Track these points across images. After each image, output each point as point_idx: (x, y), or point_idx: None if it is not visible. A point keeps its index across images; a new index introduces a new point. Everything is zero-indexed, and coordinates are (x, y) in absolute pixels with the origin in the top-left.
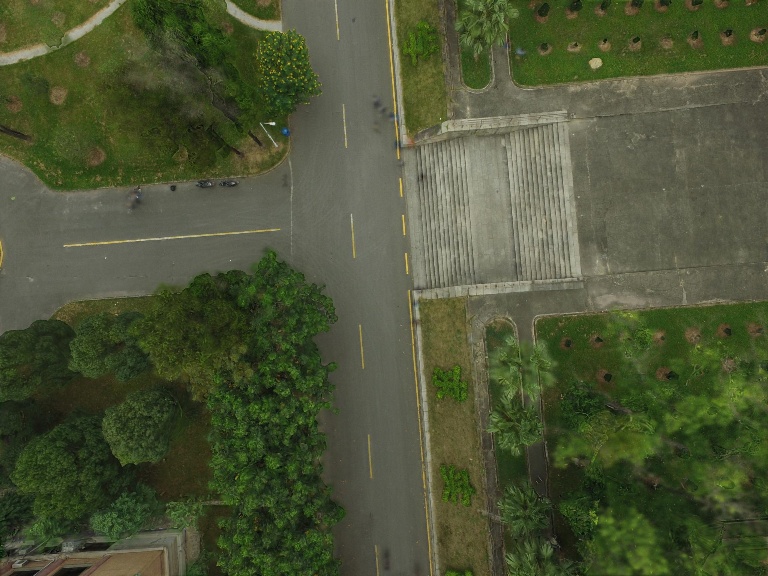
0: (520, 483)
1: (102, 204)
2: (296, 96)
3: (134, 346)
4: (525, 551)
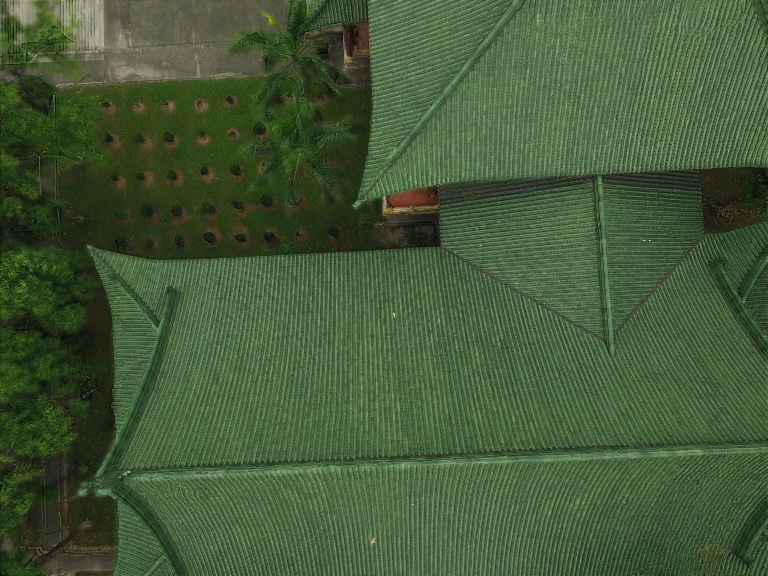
0: None
1: None
2: None
3: None
4: None
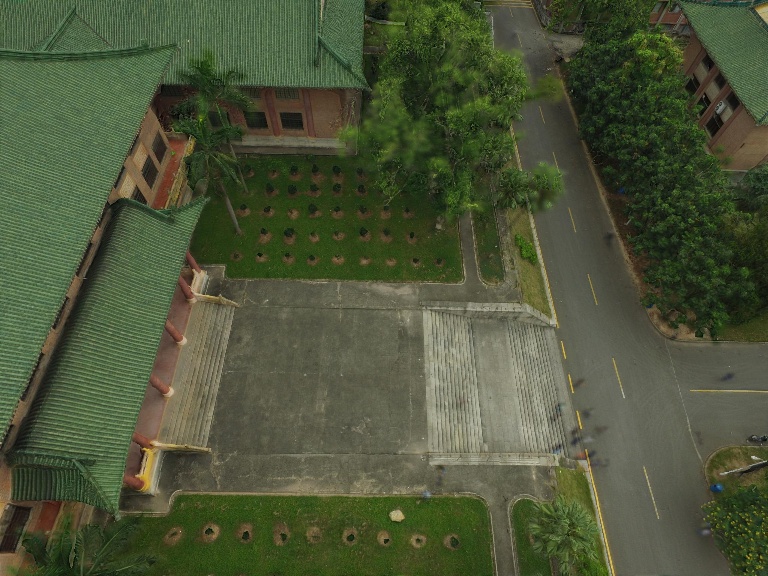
0: (475, 184)
1: None
2: None
3: None
4: (508, 123)
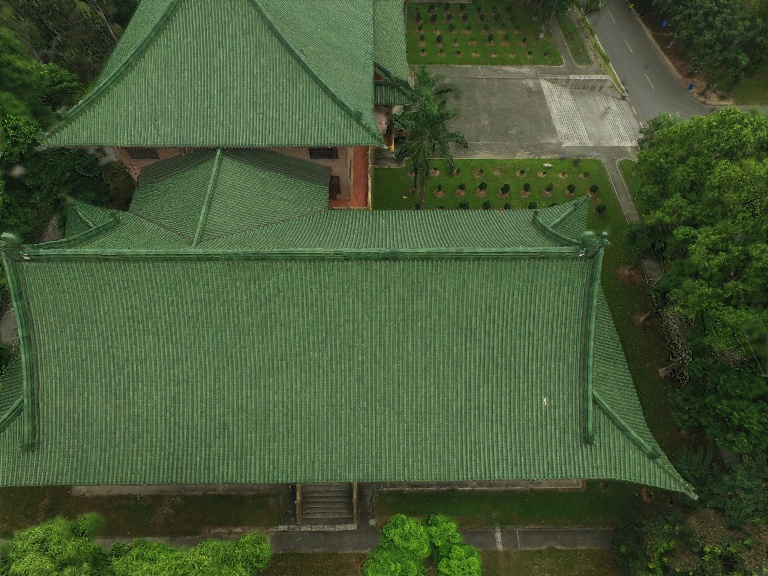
0: (561, 17)
1: None
2: None
3: None
4: None
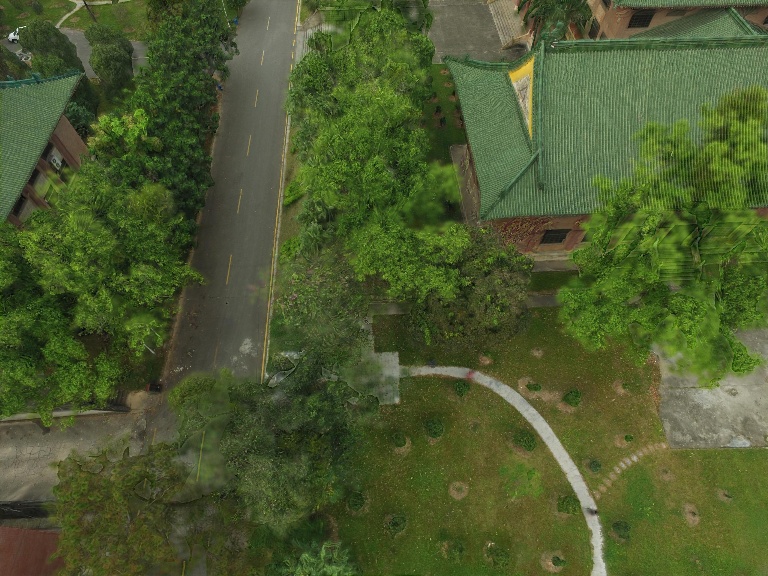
0: None
1: None
2: (243, 0)
3: (122, 43)
4: None
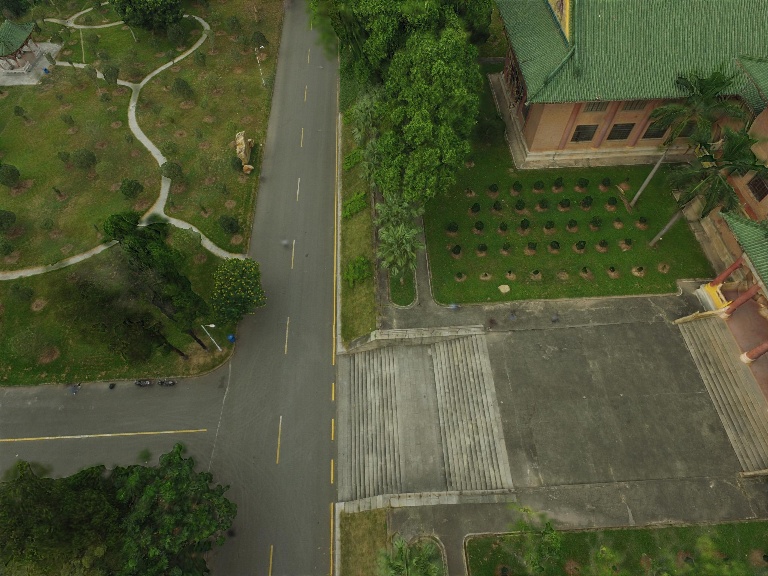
0: None
1: (37, 399)
2: (243, 307)
3: None
4: None
